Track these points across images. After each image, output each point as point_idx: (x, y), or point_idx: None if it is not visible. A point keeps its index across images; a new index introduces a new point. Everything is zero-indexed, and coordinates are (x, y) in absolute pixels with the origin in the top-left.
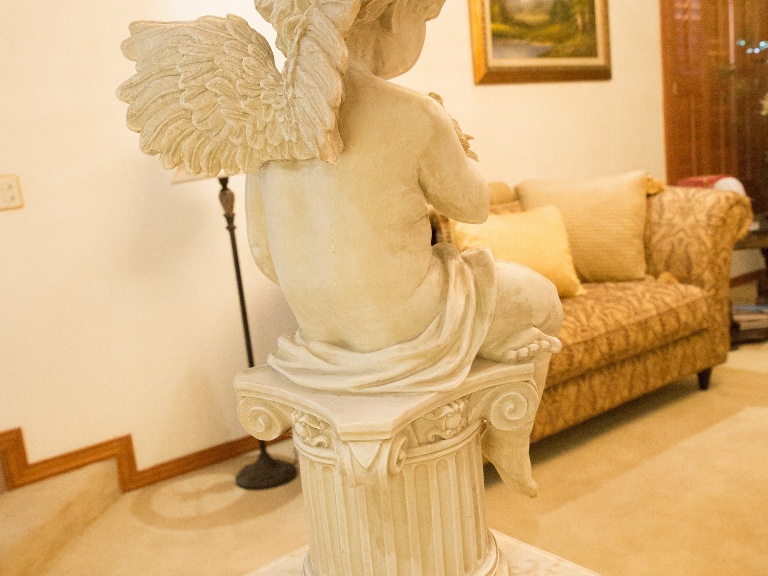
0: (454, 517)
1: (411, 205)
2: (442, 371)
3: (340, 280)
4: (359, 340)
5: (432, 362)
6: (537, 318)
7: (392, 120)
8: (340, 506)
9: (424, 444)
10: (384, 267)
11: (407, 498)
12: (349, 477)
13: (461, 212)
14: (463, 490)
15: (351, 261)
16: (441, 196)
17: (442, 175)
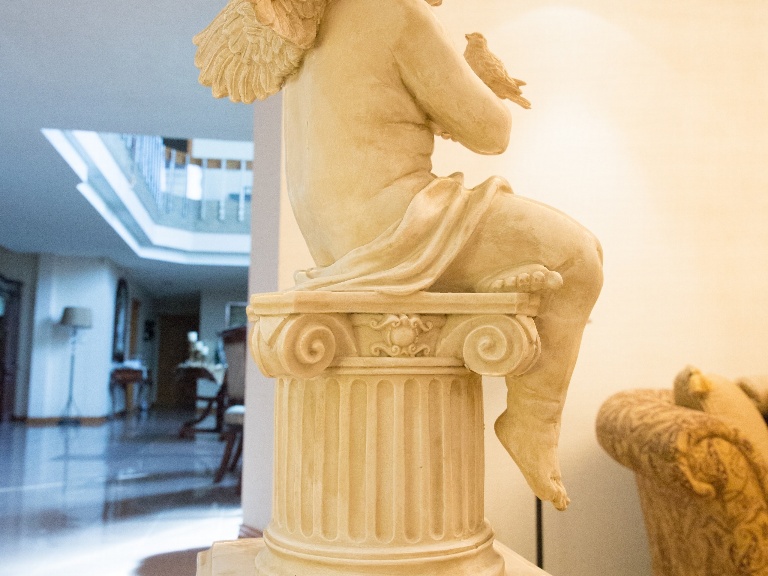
0: (395, 457)
1: (383, 99)
2: (391, 273)
3: (311, 177)
4: (333, 249)
5: (389, 268)
6: (548, 256)
7: (365, 11)
8: (284, 423)
9: (365, 356)
10: (347, 160)
11: (340, 417)
12: (255, 355)
13: (463, 129)
14: (415, 431)
15: (319, 154)
16: (432, 104)
17: (425, 75)
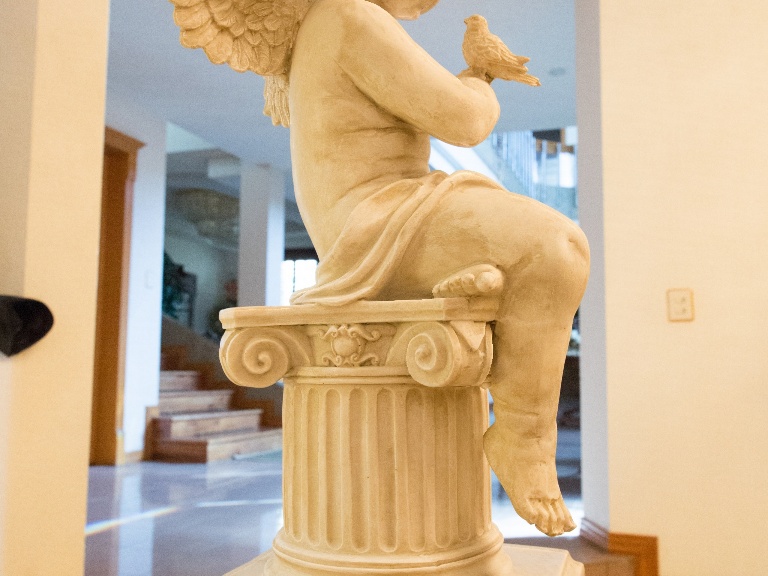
0: (341, 465)
1: (335, 111)
2: (332, 284)
3: None
4: None
5: None
6: (498, 254)
7: (314, 28)
8: None
9: None
10: (310, 175)
11: (301, 424)
12: None
13: (425, 126)
14: (364, 441)
15: None
16: (389, 106)
17: (372, 79)
